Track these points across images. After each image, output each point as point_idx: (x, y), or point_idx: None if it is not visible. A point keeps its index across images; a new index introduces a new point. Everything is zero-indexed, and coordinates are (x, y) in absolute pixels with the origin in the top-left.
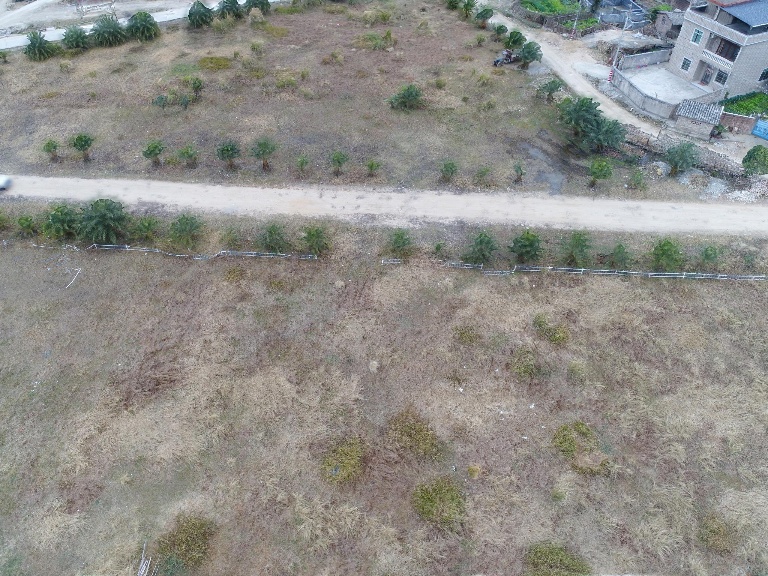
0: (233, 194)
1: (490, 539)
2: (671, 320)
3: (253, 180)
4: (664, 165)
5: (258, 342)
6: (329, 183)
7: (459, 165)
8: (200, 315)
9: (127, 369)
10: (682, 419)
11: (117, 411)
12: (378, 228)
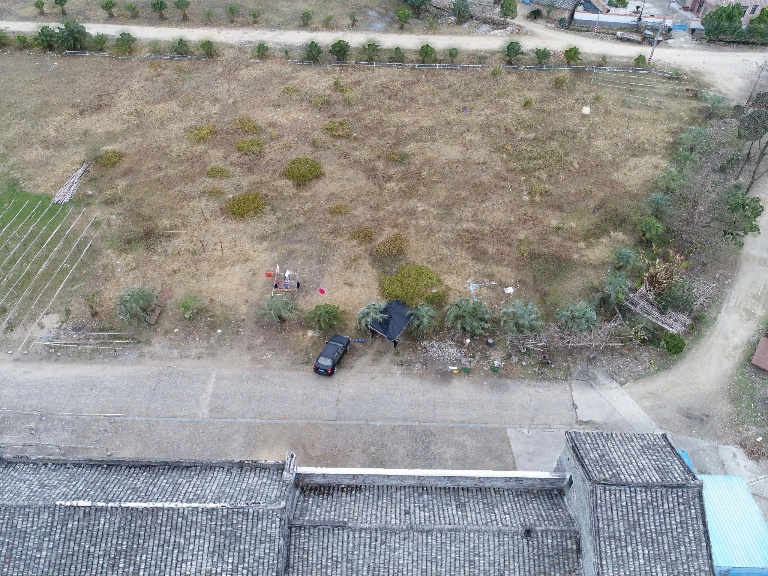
0: (160, 31)
1: (274, 157)
2: (419, 85)
3: (175, 24)
4: (455, 18)
5: (163, 92)
6: (226, 26)
7: (317, 19)
8: (130, 82)
9: (83, 102)
10: (402, 119)
11: (75, 116)
12: (252, 47)
